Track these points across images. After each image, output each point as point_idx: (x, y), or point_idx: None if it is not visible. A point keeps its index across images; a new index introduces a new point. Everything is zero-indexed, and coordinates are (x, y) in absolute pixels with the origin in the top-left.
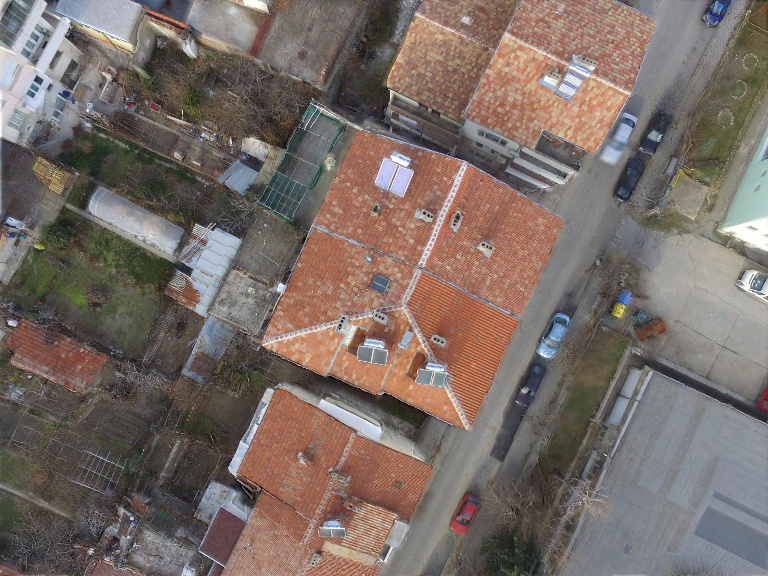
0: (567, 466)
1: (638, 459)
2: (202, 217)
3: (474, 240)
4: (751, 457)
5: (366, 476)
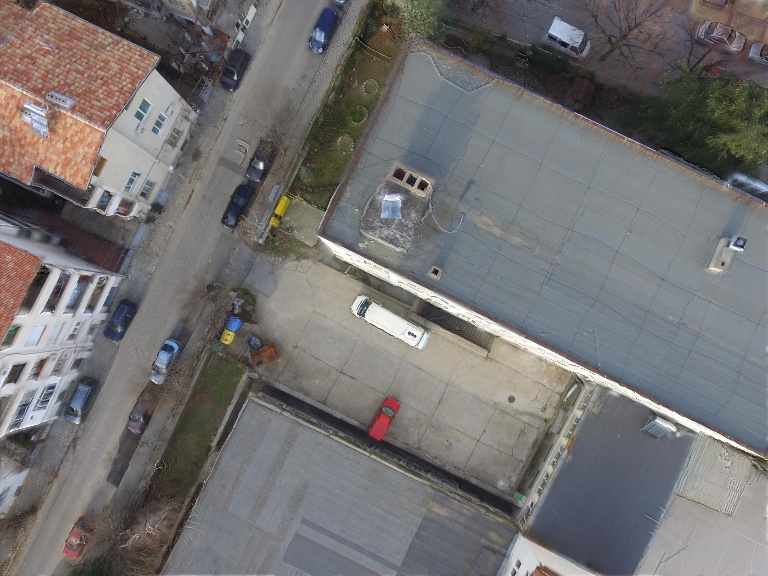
0: (187, 491)
1: (230, 486)
2: None
3: None
4: (341, 484)
5: None
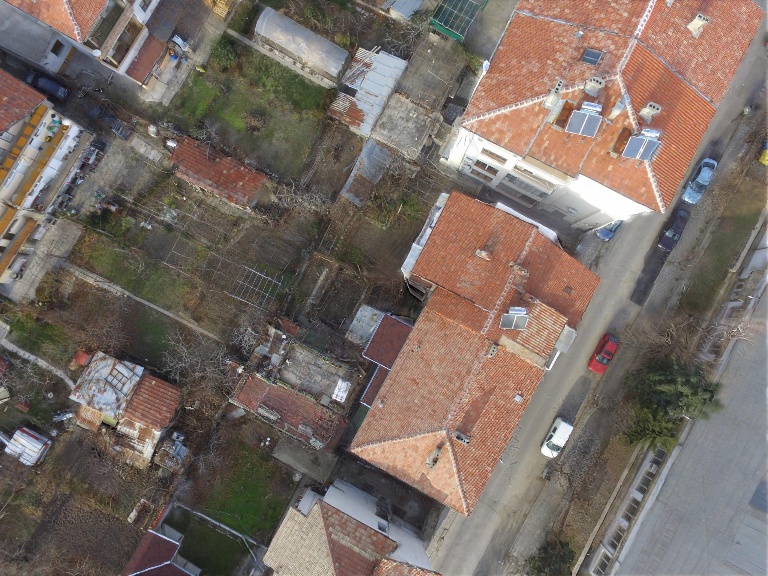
0: (705, 315)
1: None
2: (362, 46)
3: (685, 19)
4: None
5: (542, 276)
